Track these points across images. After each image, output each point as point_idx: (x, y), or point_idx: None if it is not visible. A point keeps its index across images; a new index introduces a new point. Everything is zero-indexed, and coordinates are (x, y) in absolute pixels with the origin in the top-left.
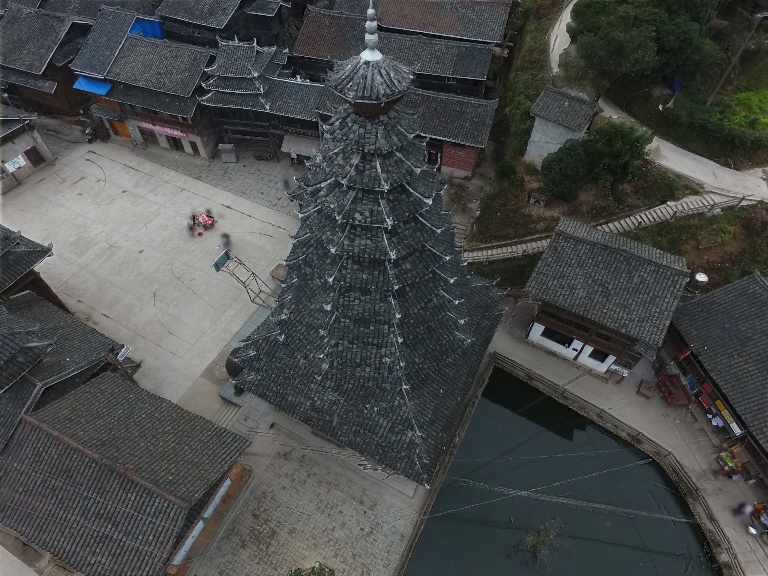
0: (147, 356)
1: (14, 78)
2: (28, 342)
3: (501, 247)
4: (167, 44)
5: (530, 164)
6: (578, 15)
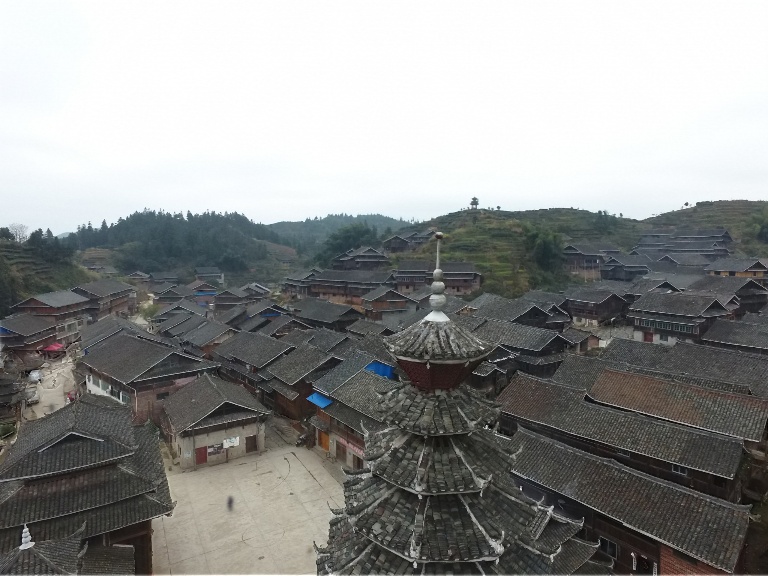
0: None
1: (277, 386)
2: None
3: None
4: (386, 380)
5: None
6: None
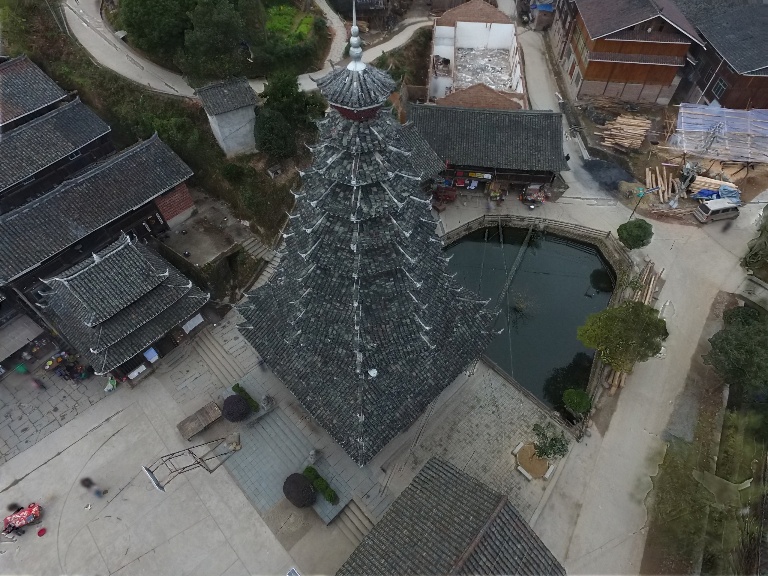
0: None
1: None
2: None
3: None
4: None
5: (237, 156)
6: (140, 26)
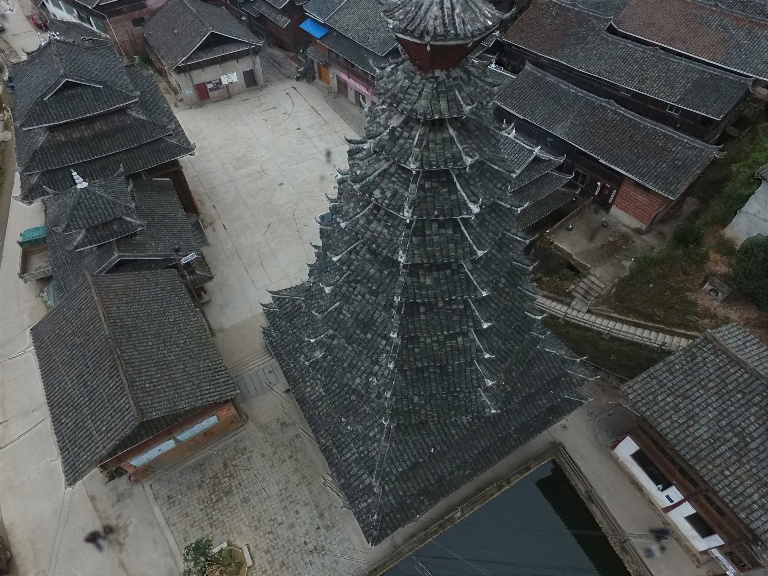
0: (233, 275)
1: (264, 9)
2: (128, 216)
3: (637, 326)
4: None
5: (729, 240)
6: None
